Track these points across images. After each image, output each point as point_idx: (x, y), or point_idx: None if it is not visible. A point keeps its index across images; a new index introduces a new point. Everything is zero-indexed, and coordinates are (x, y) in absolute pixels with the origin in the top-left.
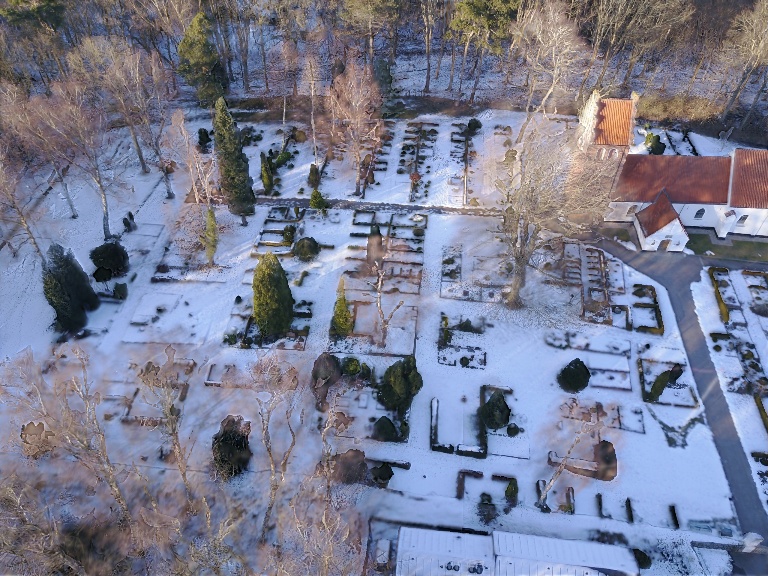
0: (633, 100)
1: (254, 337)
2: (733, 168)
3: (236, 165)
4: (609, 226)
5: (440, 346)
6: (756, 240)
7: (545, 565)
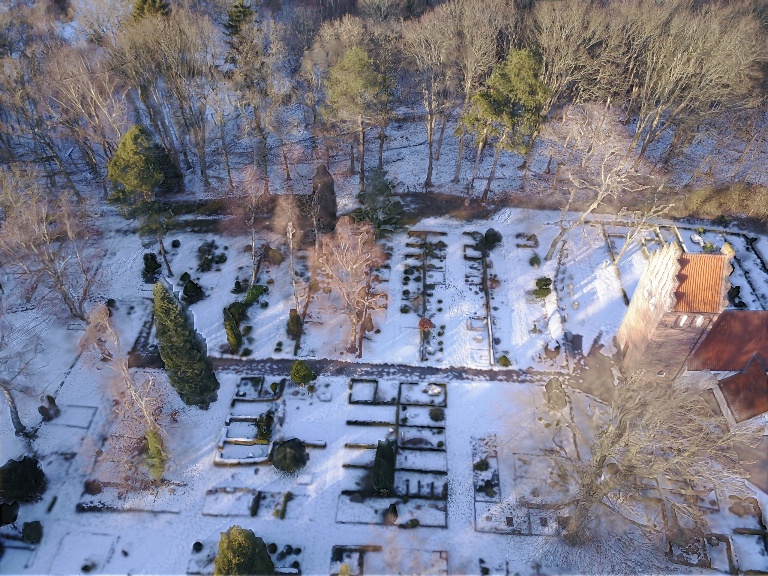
0: (727, 255)
1: None
2: None
3: (188, 358)
4: None
5: None
6: None
7: None
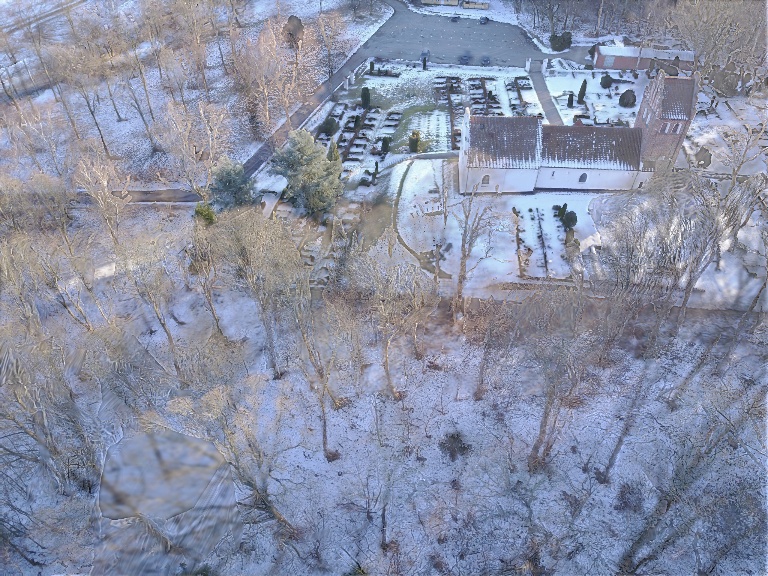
0: None
1: None
2: None
3: None
4: None
5: None
6: None
7: None
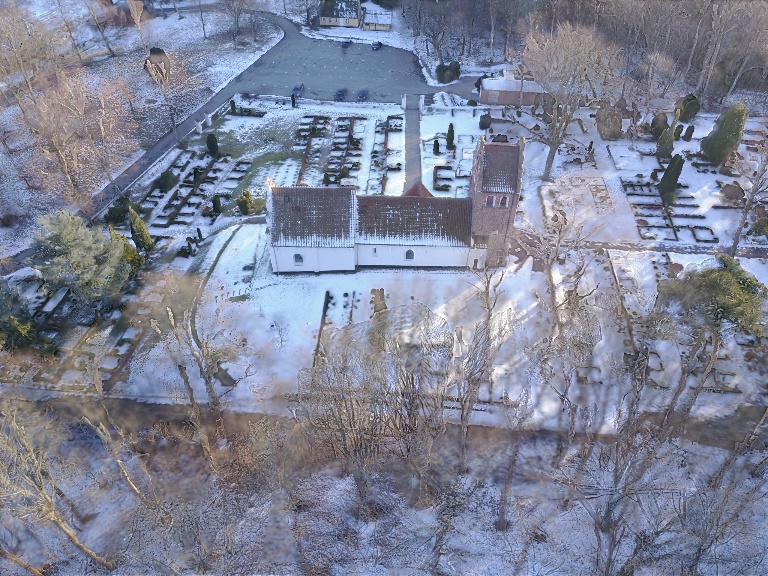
0: None
1: None
2: None
3: None
4: None
5: None
6: None
7: None
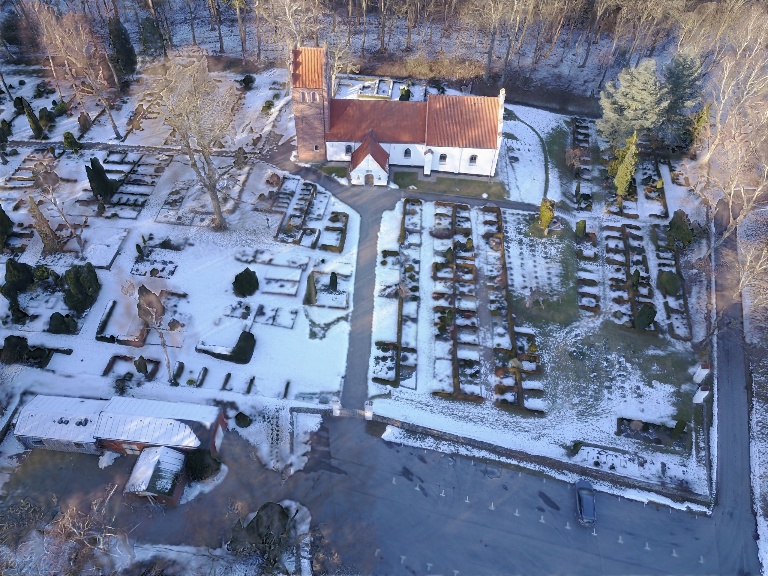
0: (324, 48)
1: None
2: (427, 111)
3: None
4: (332, 165)
5: (137, 260)
6: (459, 177)
7: (139, 418)
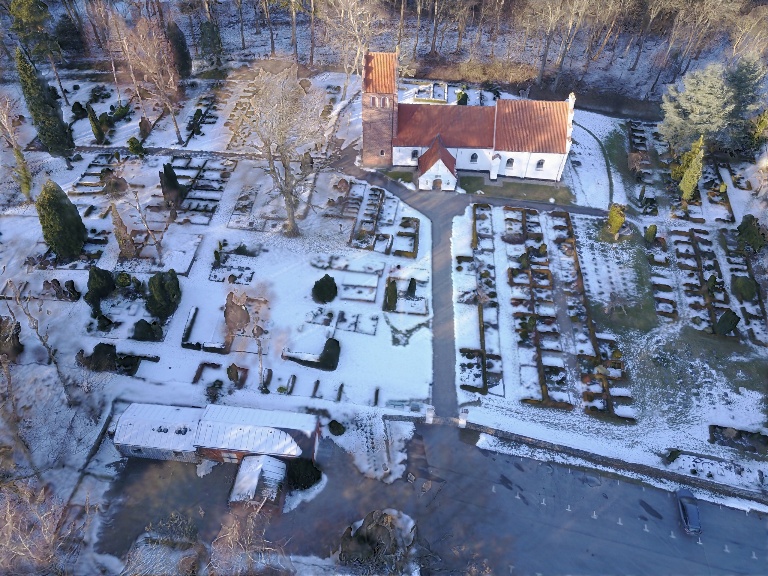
0: (396, 53)
1: (52, 260)
2: (496, 116)
3: (44, 110)
4: (397, 170)
5: (214, 266)
6: (525, 182)
7: (238, 427)
